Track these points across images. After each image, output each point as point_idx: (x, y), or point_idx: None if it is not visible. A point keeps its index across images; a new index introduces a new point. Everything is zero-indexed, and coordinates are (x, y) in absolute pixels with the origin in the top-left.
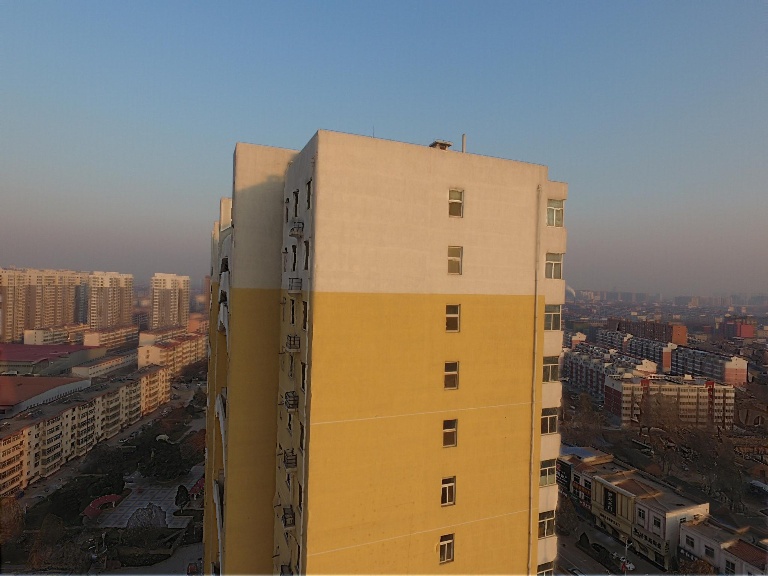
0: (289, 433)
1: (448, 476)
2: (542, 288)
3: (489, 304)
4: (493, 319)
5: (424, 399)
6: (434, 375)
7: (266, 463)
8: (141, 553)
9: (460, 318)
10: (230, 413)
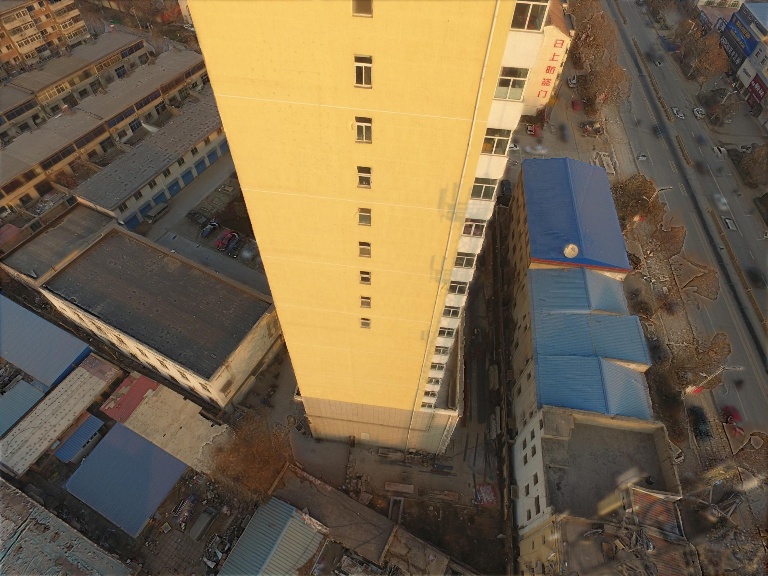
0: None
1: (361, 54)
2: None
3: None
4: None
5: None
6: None
7: None
8: None
9: None
10: None
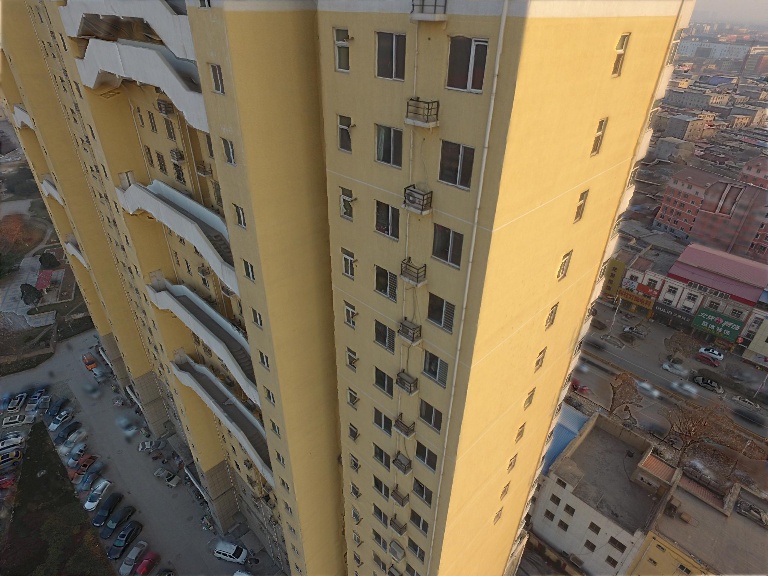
0: (386, 237)
1: (569, 251)
2: (684, 4)
3: (648, 31)
4: (644, 54)
5: (576, 172)
6: (589, 140)
7: (304, 269)
8: (14, 360)
9: (625, 55)
10: (256, 220)
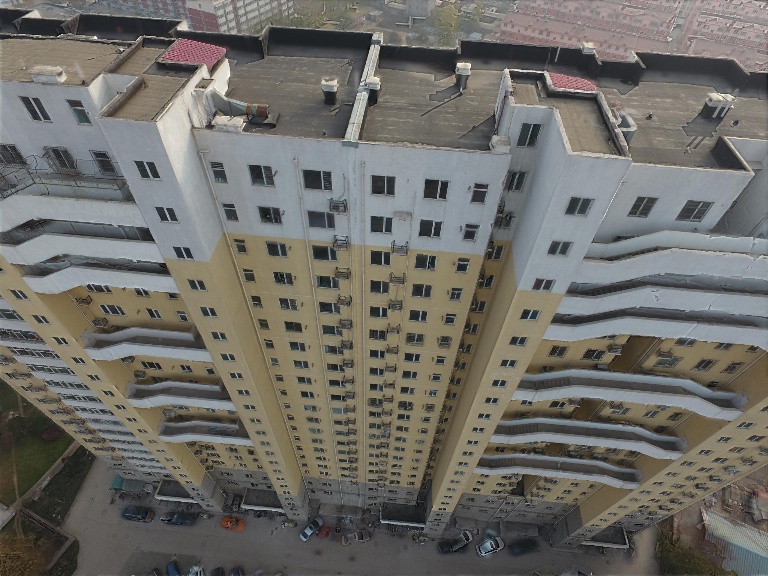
0: None
1: None
2: None
3: None
4: None
5: None
6: None
7: None
8: None
9: None
10: None
